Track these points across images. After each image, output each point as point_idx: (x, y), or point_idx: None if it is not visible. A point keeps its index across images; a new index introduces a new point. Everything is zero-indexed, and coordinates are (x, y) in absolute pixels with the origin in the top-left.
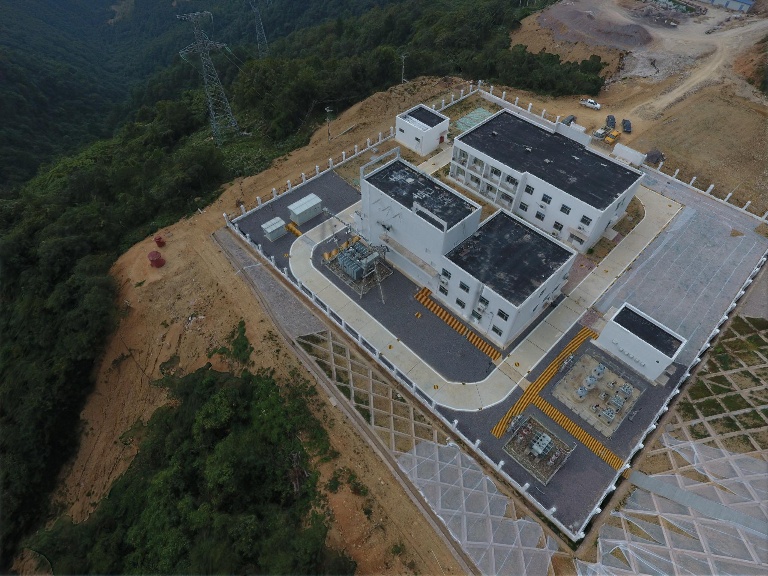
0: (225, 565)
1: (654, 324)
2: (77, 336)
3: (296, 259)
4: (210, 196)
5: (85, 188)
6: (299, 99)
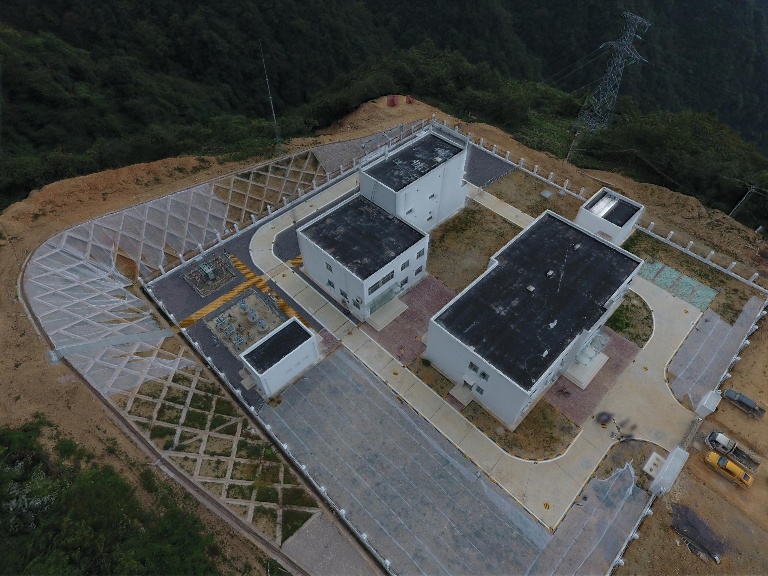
0: None
1: None
2: (339, 94)
3: None
4: (477, 121)
5: (475, 75)
6: (636, 142)
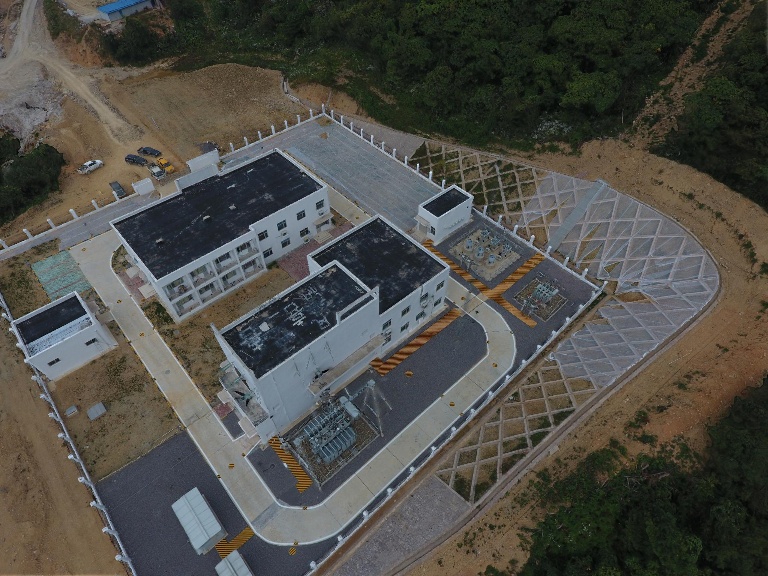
0: (767, 530)
1: (438, 197)
2: None
3: (303, 533)
4: None
5: None
6: None
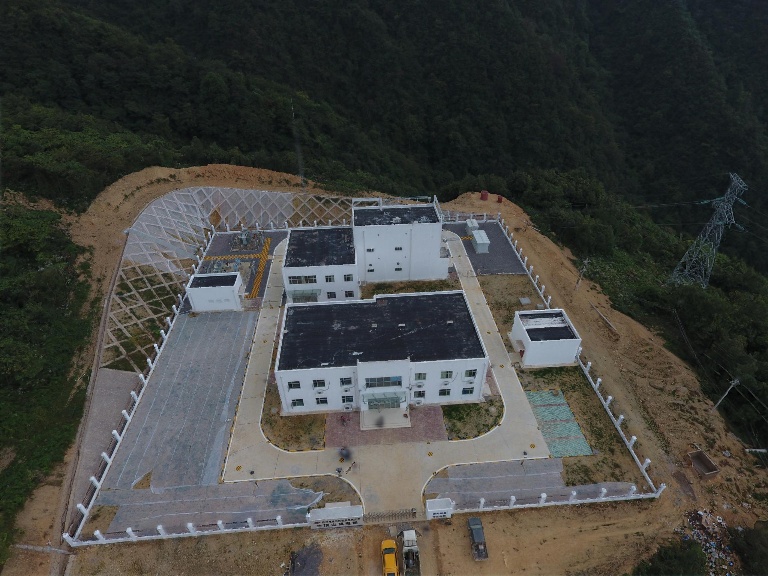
0: None
1: None
2: None
3: None
4: None
5: None
6: (689, 306)
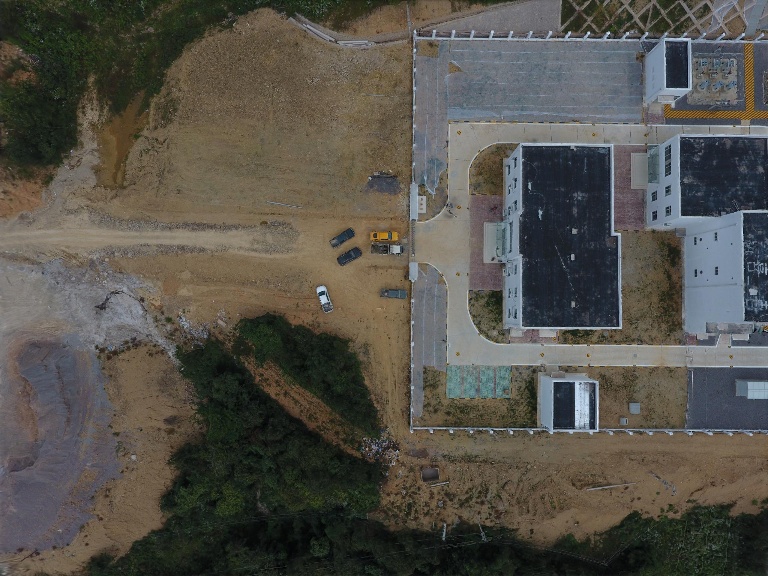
0: None
1: None
2: None
3: None
4: None
5: None
6: None
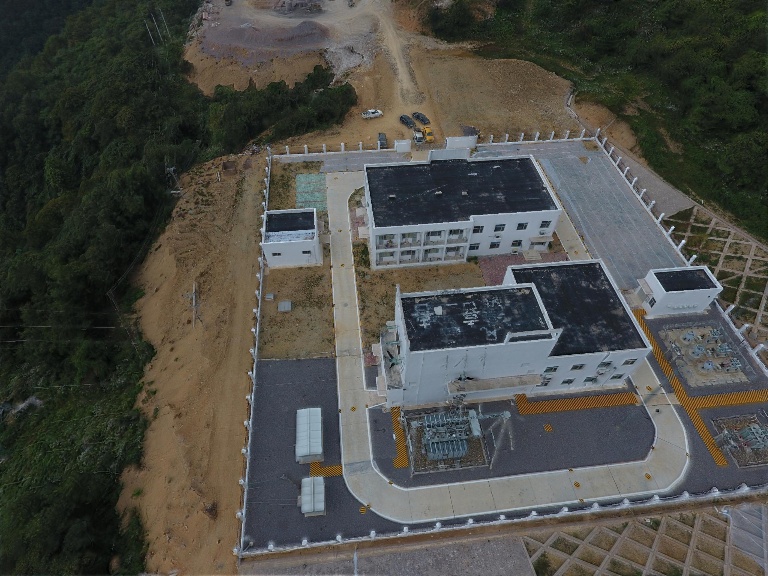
0: None
1: (678, 271)
2: None
3: (379, 502)
4: (130, 544)
5: None
6: (79, 305)
